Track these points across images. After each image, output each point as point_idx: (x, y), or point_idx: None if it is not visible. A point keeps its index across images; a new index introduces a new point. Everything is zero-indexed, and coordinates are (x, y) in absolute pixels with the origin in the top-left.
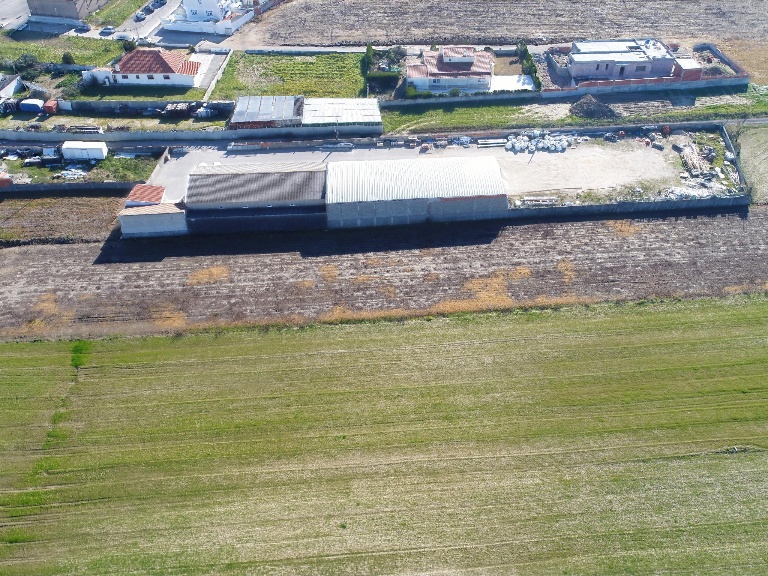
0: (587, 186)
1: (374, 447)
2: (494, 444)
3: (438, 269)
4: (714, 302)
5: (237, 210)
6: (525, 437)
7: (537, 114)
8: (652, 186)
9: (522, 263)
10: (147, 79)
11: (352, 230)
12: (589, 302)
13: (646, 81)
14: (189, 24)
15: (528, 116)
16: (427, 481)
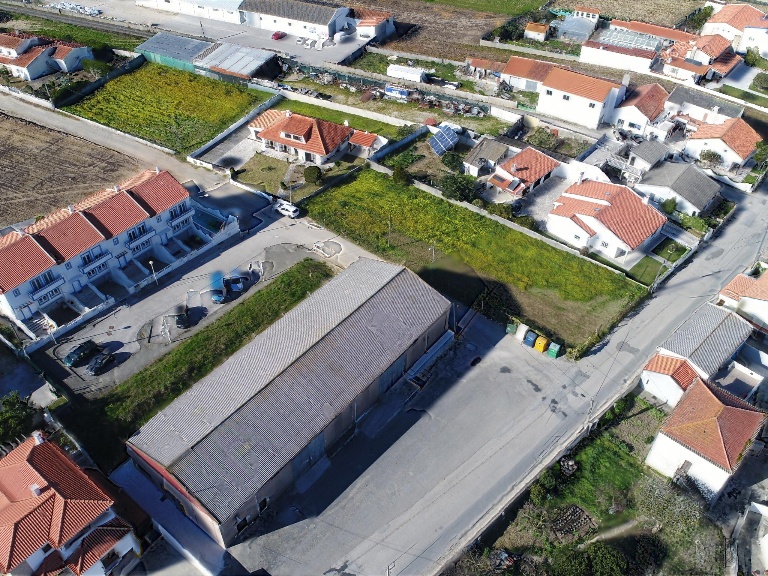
0: None
1: None
2: None
3: None
4: None
5: None
6: None
7: (33, 26)
8: None
9: None
10: None
11: None
12: None
13: None
14: (204, 209)
15: (43, 26)
16: None
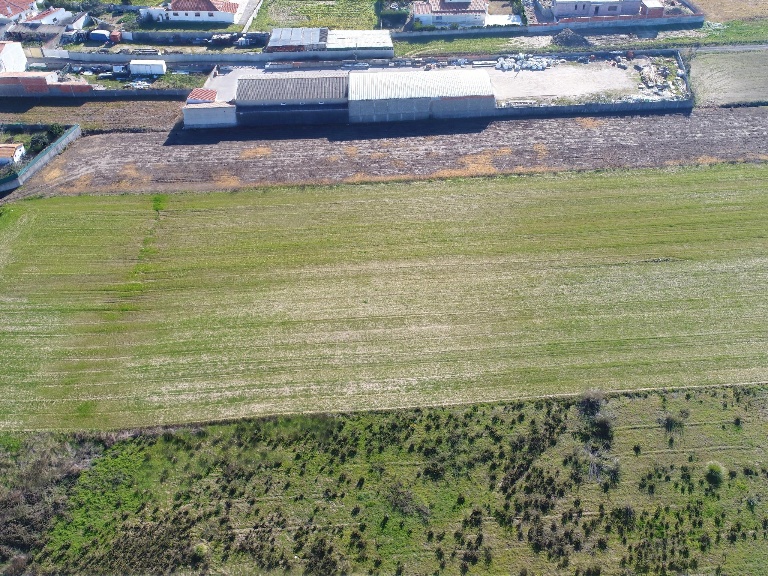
0: (561, 94)
1: (388, 258)
2: (478, 256)
3: (438, 149)
4: (655, 171)
5: (277, 106)
6: (502, 252)
7: (523, 44)
8: (614, 94)
9: (505, 145)
10: (194, 16)
11: (369, 124)
12: (557, 171)
13: (616, 18)
14: None
15: (516, 45)
16: (427, 277)
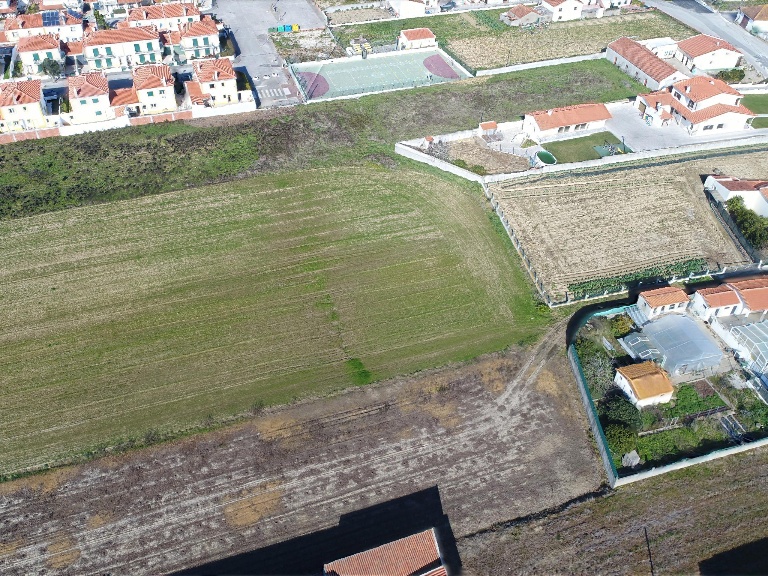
0: None
1: (21, 343)
2: None
3: None
4: None
5: None
6: None
7: None
8: None
9: None
10: None
11: None
12: None
13: None
14: None
15: None
16: None
